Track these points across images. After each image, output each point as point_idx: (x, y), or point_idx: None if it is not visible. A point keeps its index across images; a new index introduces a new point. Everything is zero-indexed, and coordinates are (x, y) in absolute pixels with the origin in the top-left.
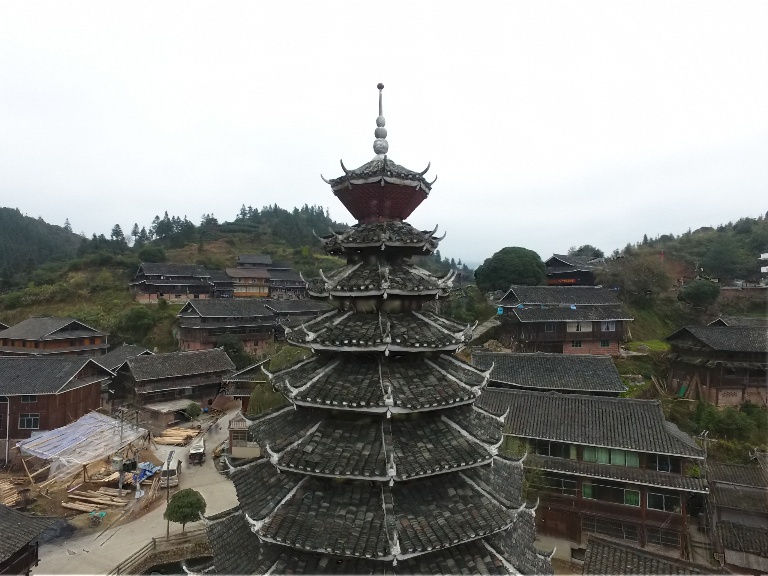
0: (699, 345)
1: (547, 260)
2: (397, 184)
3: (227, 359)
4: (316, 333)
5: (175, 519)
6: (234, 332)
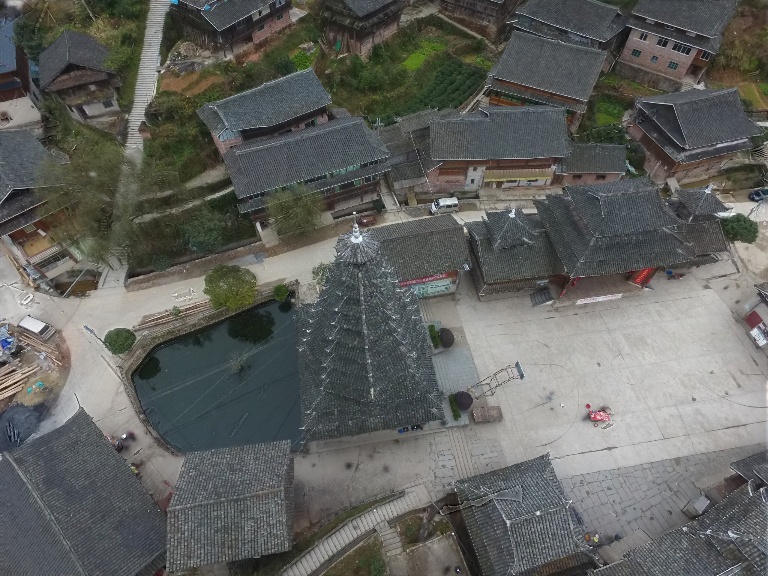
0: (347, 8)
1: None
2: None
3: None
4: None
5: None
6: None
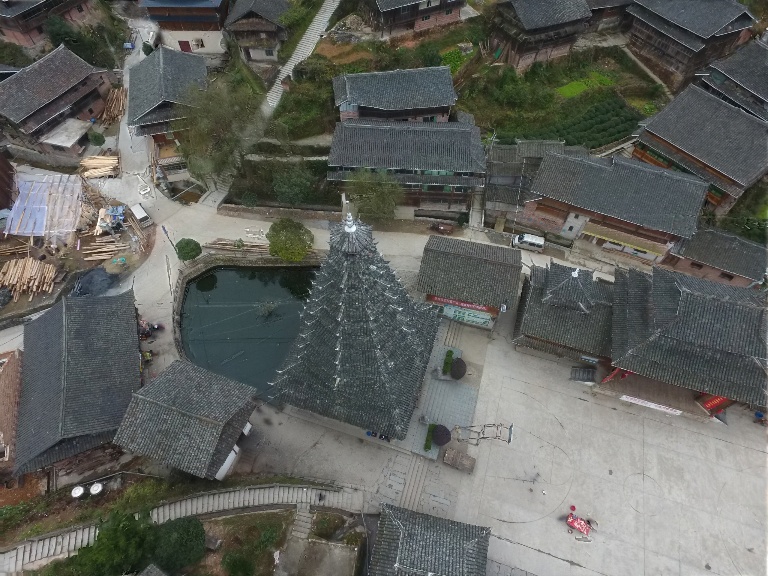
0: (517, 18)
1: None
2: None
3: (79, 61)
4: None
5: (189, 259)
6: (50, 5)
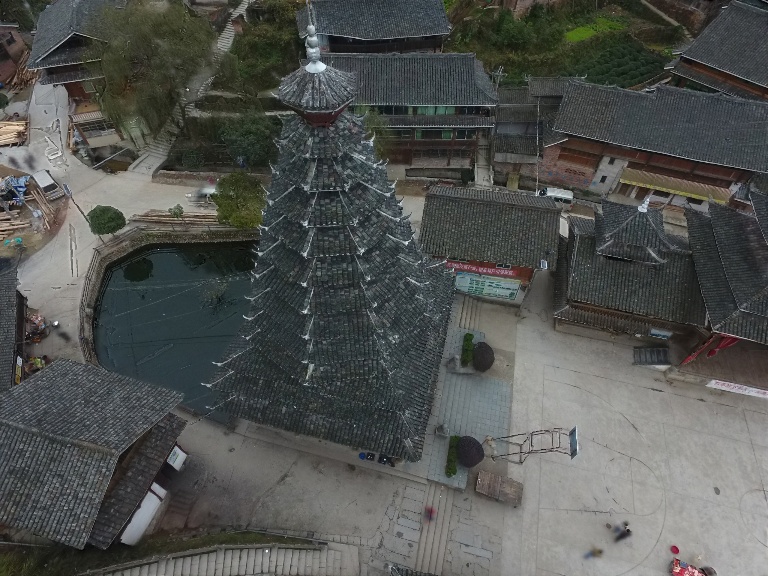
0: None
1: None
2: None
3: None
4: (308, 219)
5: (106, 233)
6: None
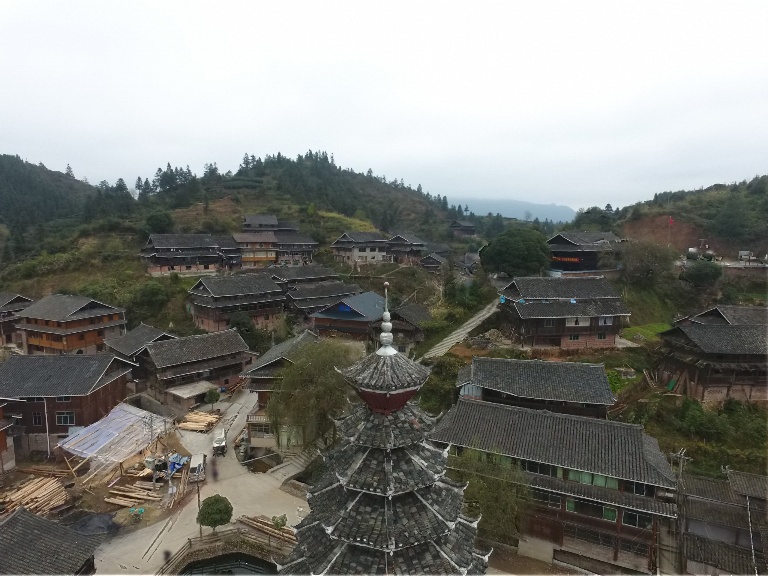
0: (691, 344)
1: (552, 237)
2: (401, 393)
3: (240, 340)
4: (334, 525)
5: (207, 524)
6: (245, 309)
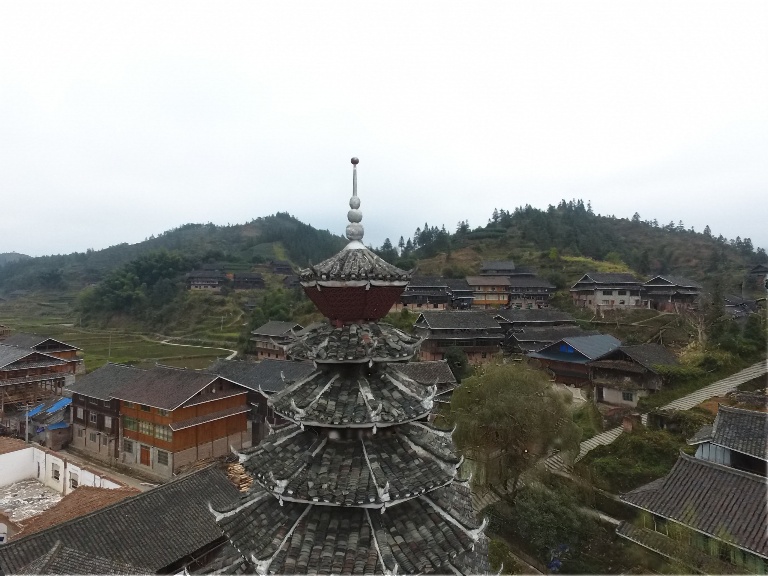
0: None
1: None
2: (337, 287)
3: (449, 372)
4: (249, 455)
5: None
6: (461, 344)
